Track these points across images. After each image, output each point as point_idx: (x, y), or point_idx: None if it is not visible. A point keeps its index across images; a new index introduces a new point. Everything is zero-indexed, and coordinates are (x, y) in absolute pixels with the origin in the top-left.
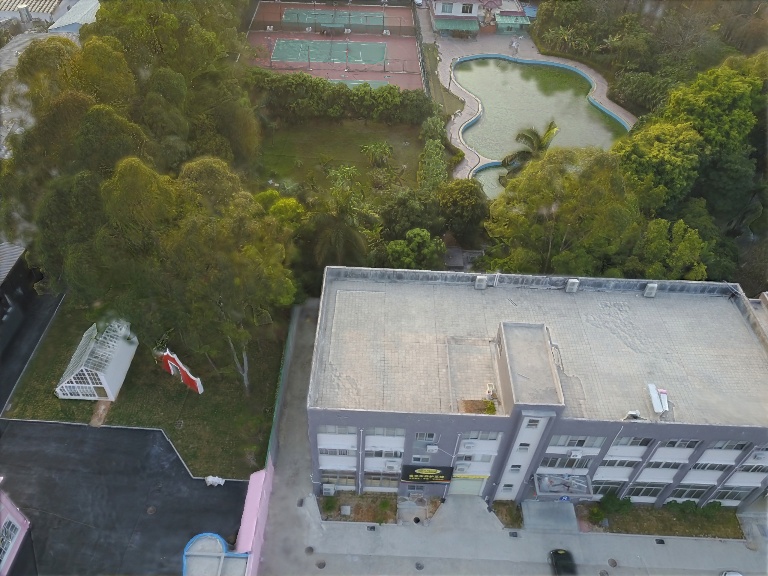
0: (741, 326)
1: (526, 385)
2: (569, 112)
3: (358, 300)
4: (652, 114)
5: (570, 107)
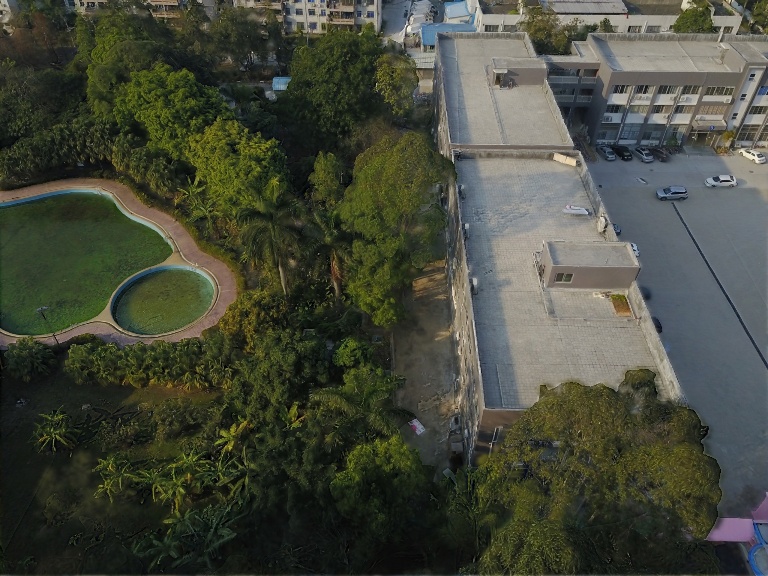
0: (486, 162)
1: (615, 261)
2: (14, 229)
3: (515, 387)
4: (139, 149)
5: (1, 226)
